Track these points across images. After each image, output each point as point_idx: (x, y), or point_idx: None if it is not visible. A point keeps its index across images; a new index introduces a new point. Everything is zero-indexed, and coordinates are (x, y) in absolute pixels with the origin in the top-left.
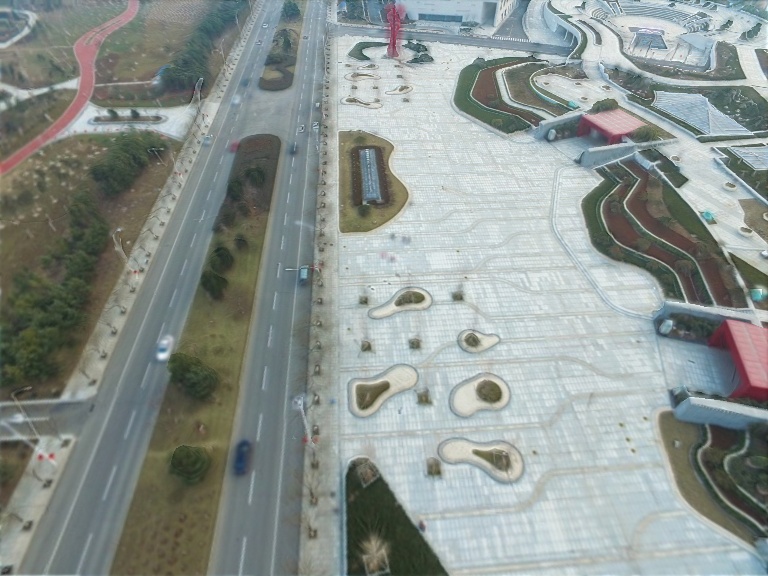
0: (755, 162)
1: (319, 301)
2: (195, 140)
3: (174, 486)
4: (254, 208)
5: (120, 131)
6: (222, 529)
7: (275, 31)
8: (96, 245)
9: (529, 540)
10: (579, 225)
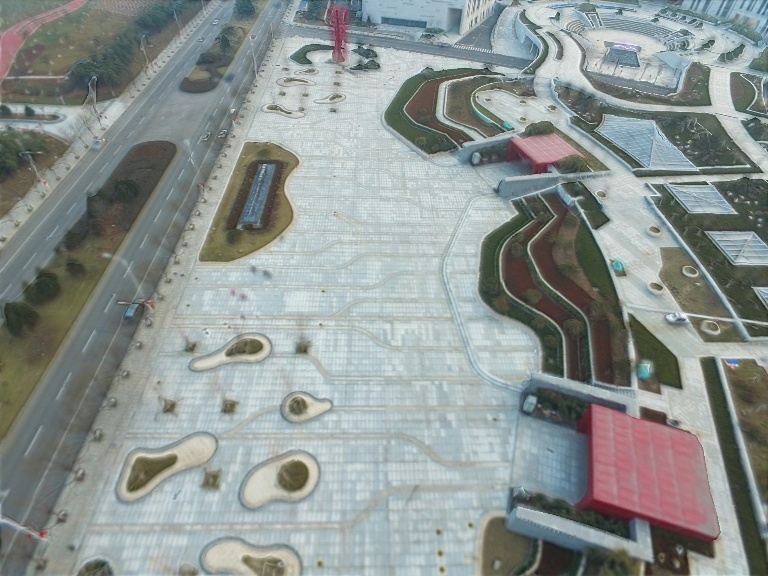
0: (691, 203)
1: (138, 345)
2: (81, 144)
3: None
4: (112, 226)
5: (3, 130)
6: None
7: (223, 28)
8: None
9: None
10: (472, 267)
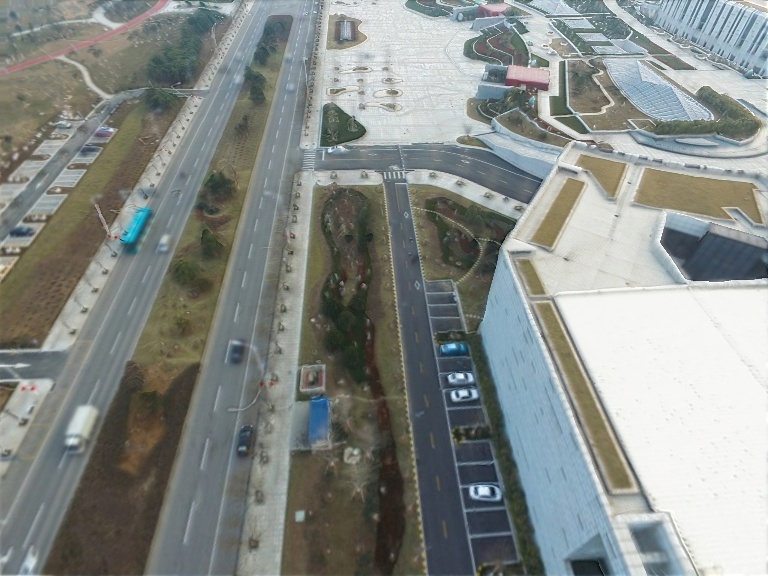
0: (573, 25)
1: (314, 68)
2: (241, 15)
3: (250, 105)
4: (279, 40)
5: (195, 10)
6: (271, 116)
7: None
8: (197, 45)
9: (398, 122)
10: (460, 50)
